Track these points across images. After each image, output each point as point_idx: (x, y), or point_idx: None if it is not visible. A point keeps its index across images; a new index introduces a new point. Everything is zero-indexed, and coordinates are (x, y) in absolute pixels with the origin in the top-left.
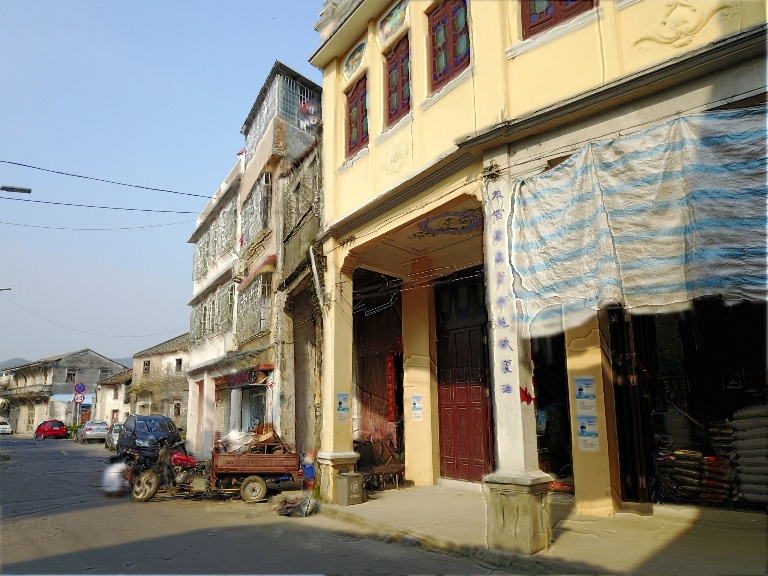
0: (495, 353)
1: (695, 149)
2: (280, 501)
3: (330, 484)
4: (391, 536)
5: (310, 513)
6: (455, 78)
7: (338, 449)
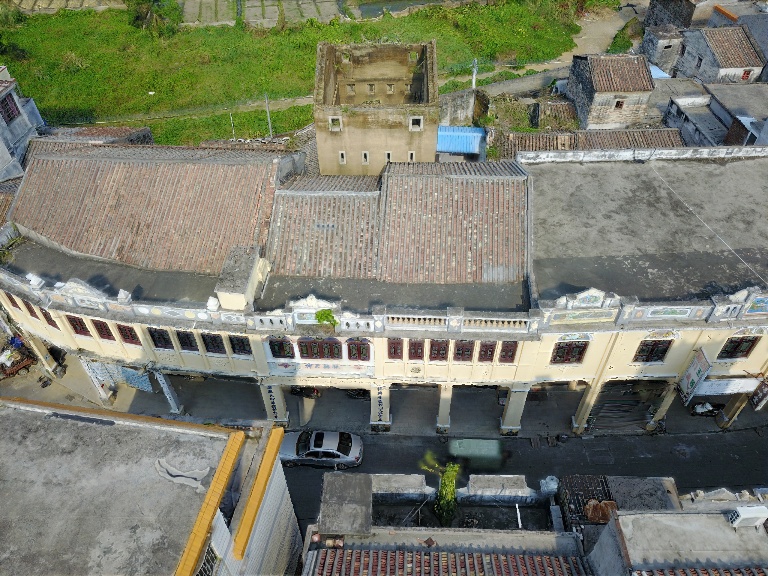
0: (93, 381)
1: (121, 370)
2: (34, 370)
3: (53, 374)
4: (81, 400)
5: (51, 382)
6: (58, 331)
7: (52, 367)
